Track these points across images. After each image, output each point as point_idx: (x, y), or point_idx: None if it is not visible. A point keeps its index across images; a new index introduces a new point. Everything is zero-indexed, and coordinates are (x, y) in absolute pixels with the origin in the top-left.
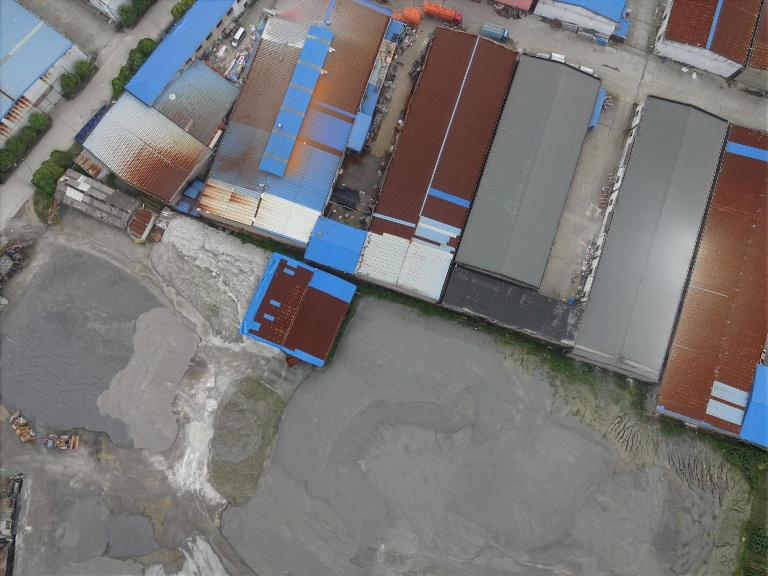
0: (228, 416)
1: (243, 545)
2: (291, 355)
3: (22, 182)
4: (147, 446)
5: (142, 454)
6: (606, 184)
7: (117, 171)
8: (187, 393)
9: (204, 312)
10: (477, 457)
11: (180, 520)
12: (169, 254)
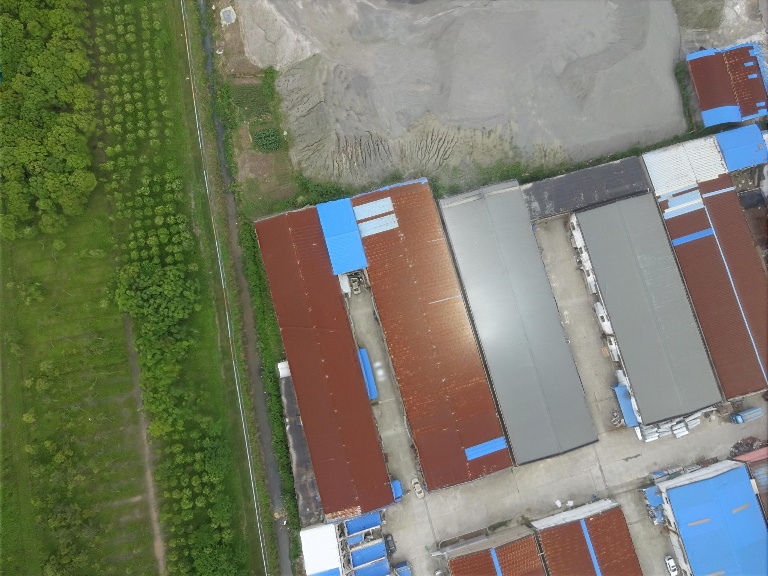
0: None
1: None
2: (714, 49)
3: None
4: None
5: None
6: None
7: None
8: None
9: None
10: (539, 58)
11: None
12: None
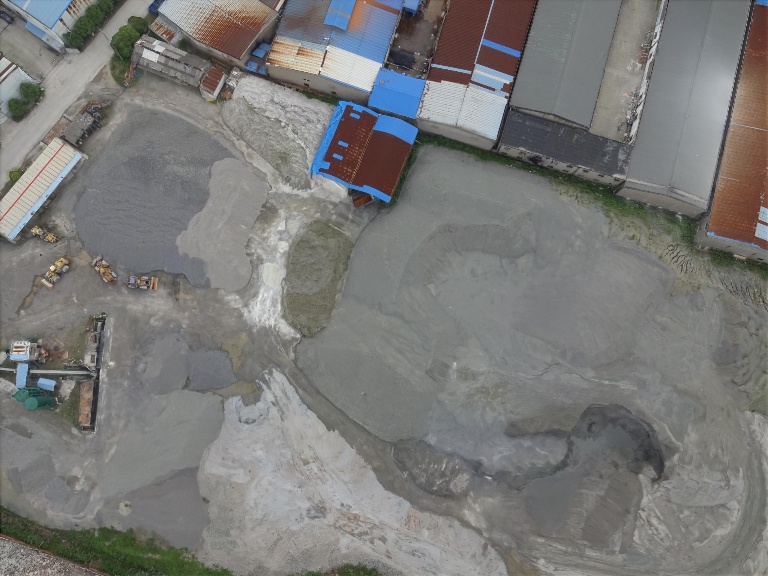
0: (301, 252)
1: (319, 373)
2: (360, 191)
3: (99, 50)
4: (223, 285)
5: (218, 293)
6: (644, 42)
7: (190, 32)
8: (260, 236)
9: (274, 161)
10: (541, 280)
11: (256, 354)
12: (240, 107)
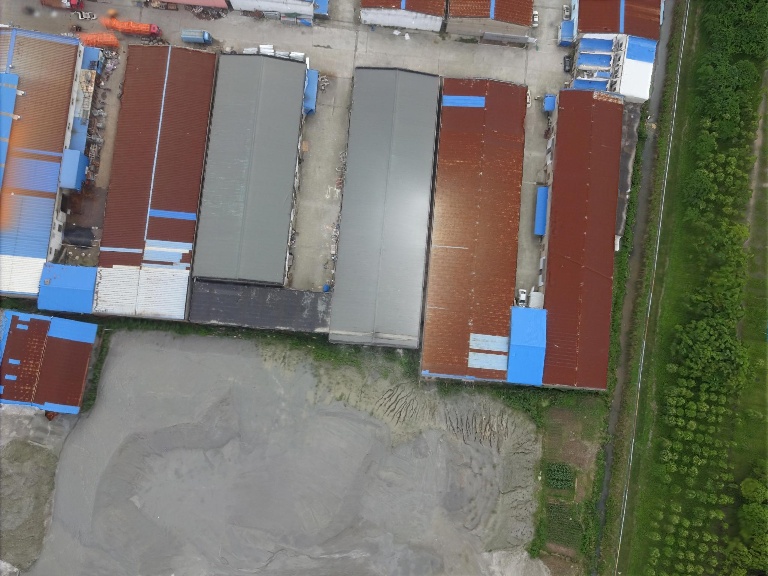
0: None
1: None
2: (42, 409)
3: None
4: None
5: None
6: (339, 164)
7: None
8: None
9: None
10: (250, 465)
11: None
12: None
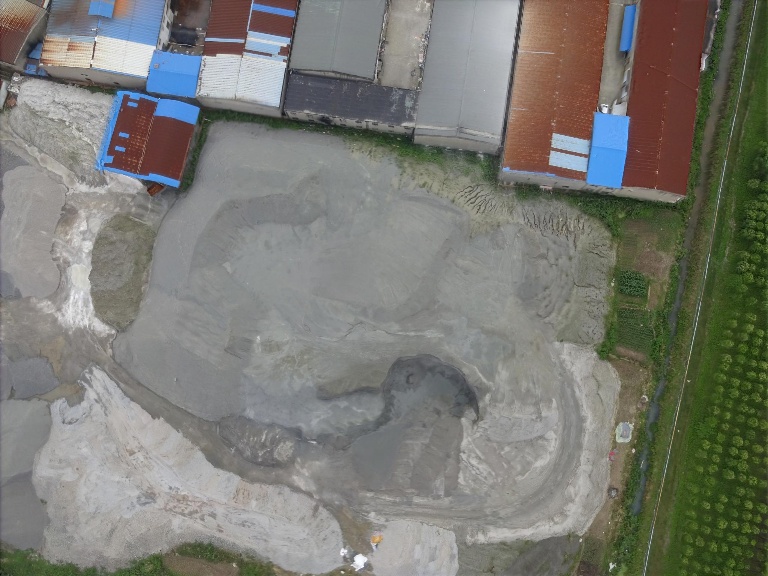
0: (100, 249)
1: (135, 366)
2: (147, 180)
3: None
4: (33, 293)
5: (30, 302)
6: None
7: None
8: (63, 239)
9: (66, 162)
10: (335, 242)
11: (75, 355)
12: (23, 112)
